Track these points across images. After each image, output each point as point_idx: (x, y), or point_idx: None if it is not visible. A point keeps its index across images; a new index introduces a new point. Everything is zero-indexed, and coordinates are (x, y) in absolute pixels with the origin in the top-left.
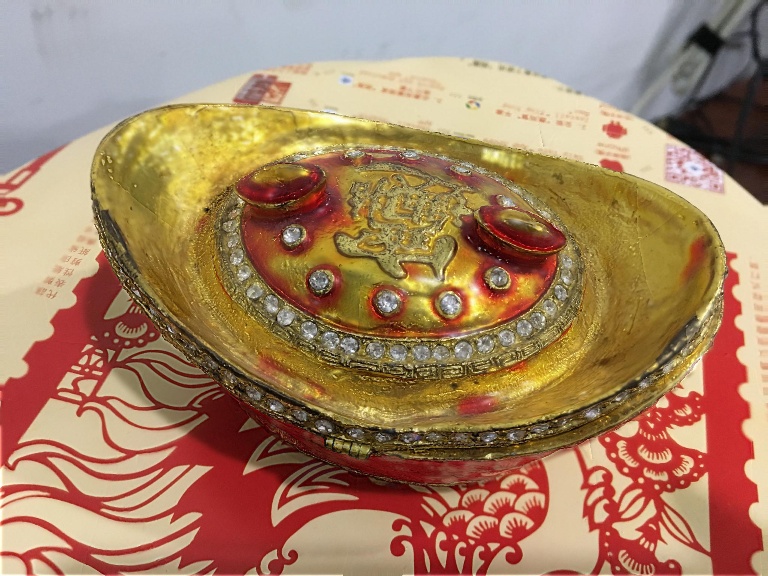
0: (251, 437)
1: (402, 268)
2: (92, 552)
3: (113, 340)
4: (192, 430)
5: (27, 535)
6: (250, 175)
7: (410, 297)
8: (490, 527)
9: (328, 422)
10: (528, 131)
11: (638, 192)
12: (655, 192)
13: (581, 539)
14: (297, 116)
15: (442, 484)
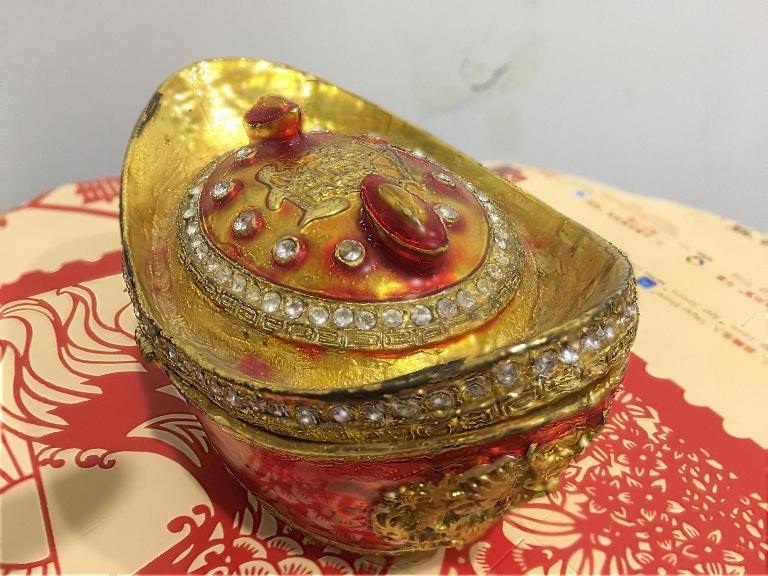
0: None
1: (280, 203)
2: (26, 365)
3: None
4: None
5: (15, 331)
6: None
7: (266, 229)
8: None
9: None
10: (738, 307)
11: (610, 269)
12: (619, 269)
13: None
14: (394, 121)
15: (250, 491)
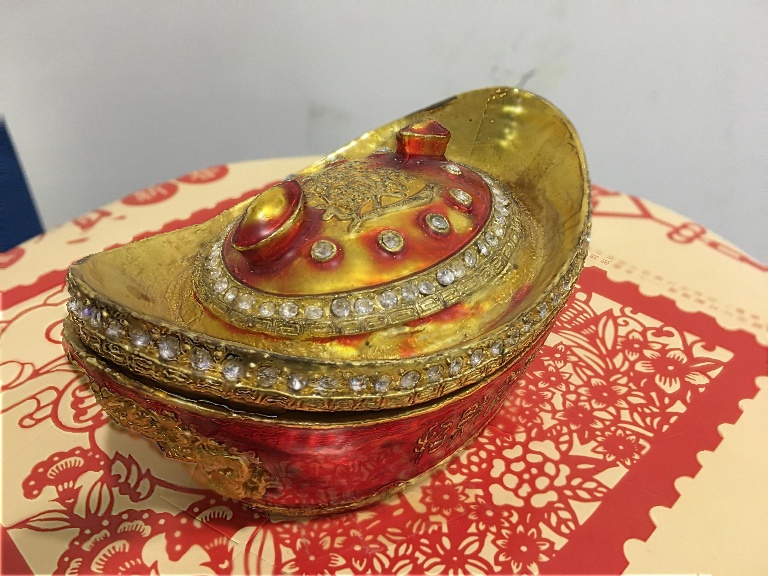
0: None
1: None
2: None
3: None
4: None
5: None
6: None
7: None
8: None
9: None
10: None
11: None
12: None
13: (119, 442)
14: (576, 216)
15: None
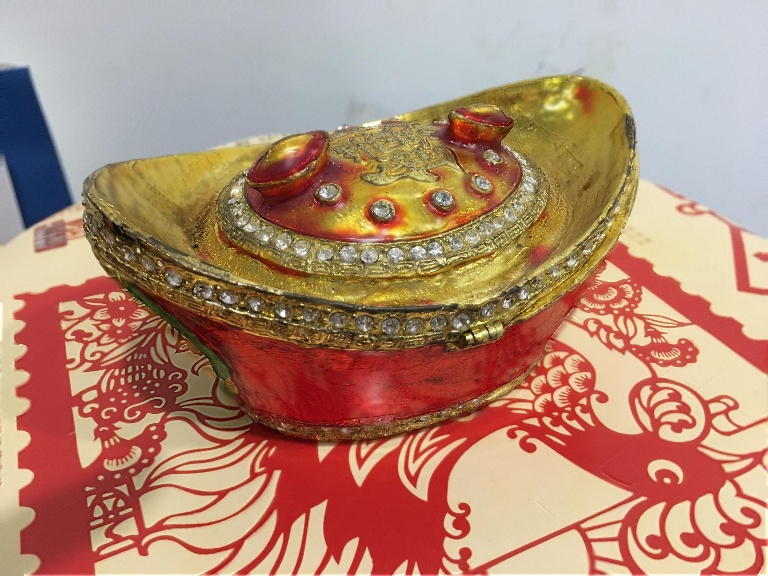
0: (335, 459)
1: (432, 174)
2: None
3: (113, 477)
4: (277, 489)
5: None
6: (257, 164)
7: (453, 191)
8: (568, 393)
9: (464, 314)
10: None
11: (507, 93)
12: (521, 85)
13: (625, 362)
14: (208, 155)
15: (522, 374)
